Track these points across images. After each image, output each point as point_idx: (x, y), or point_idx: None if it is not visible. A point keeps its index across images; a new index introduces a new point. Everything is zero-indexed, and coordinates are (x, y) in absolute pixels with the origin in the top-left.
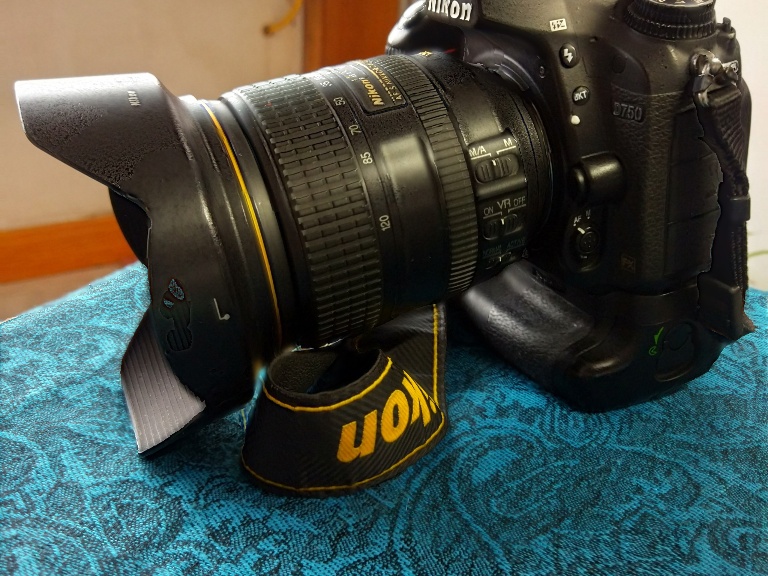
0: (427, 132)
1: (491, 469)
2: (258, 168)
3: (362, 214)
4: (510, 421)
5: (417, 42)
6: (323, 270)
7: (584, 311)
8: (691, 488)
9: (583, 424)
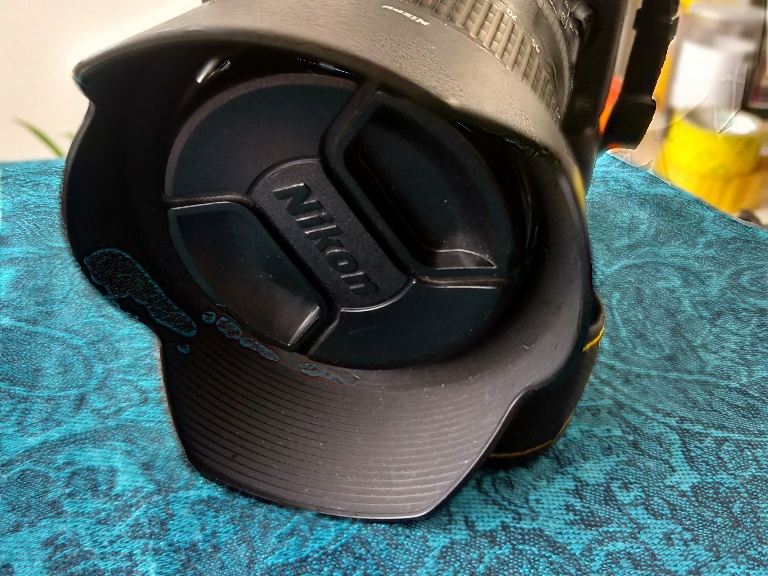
0: (538, 6)
1: None
2: None
3: None
4: None
5: None
6: None
7: None
8: (684, 271)
9: None
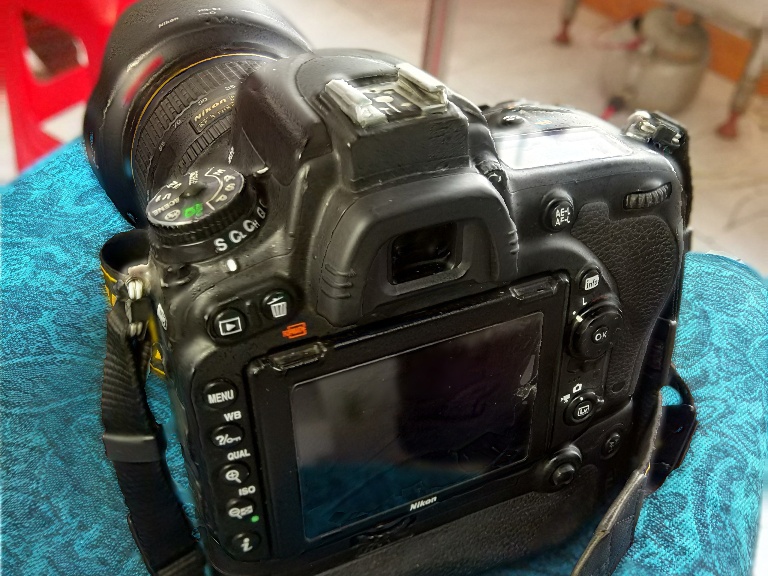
0: (180, 161)
1: None
2: None
3: None
4: None
5: None
6: None
7: None
8: (73, 572)
9: None
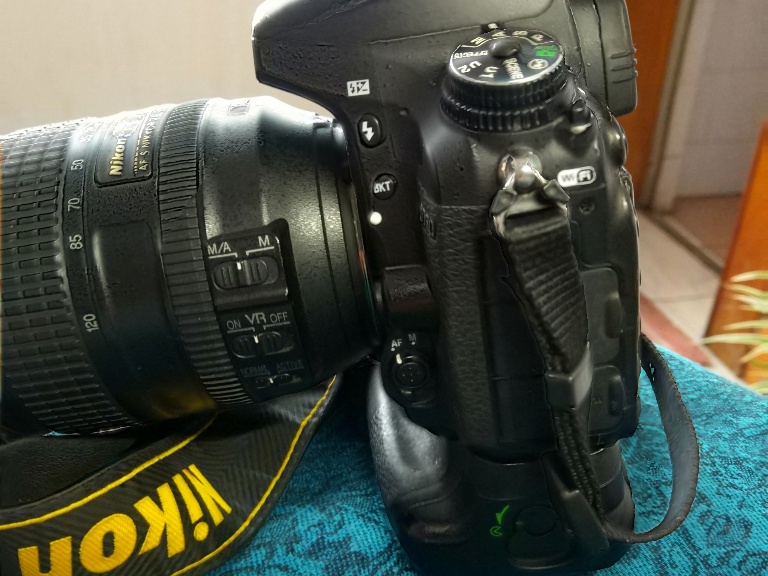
0: (161, 216)
1: None
2: None
3: (60, 309)
4: (313, 566)
5: None
6: (16, 367)
7: (443, 449)
8: None
9: None
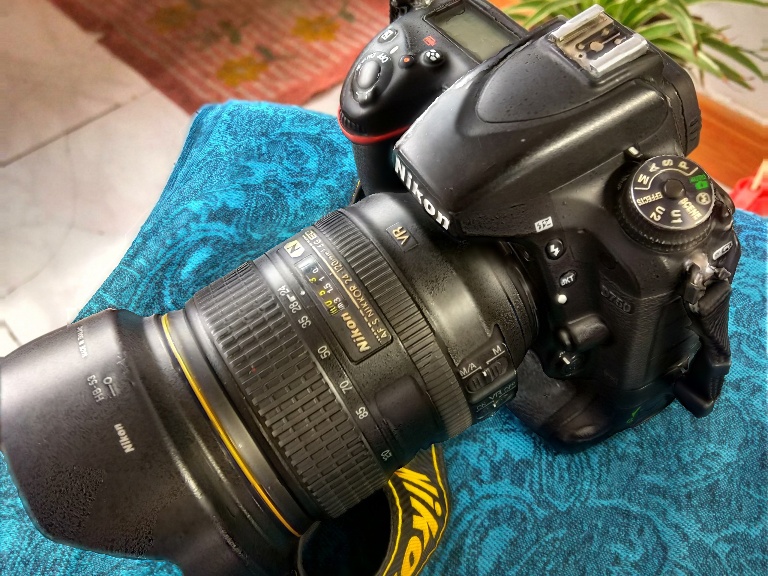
0: (417, 366)
1: (493, 555)
2: (260, 452)
3: (365, 460)
4: (504, 485)
5: (376, 120)
6: None
7: None
8: (660, 550)
9: (567, 475)
